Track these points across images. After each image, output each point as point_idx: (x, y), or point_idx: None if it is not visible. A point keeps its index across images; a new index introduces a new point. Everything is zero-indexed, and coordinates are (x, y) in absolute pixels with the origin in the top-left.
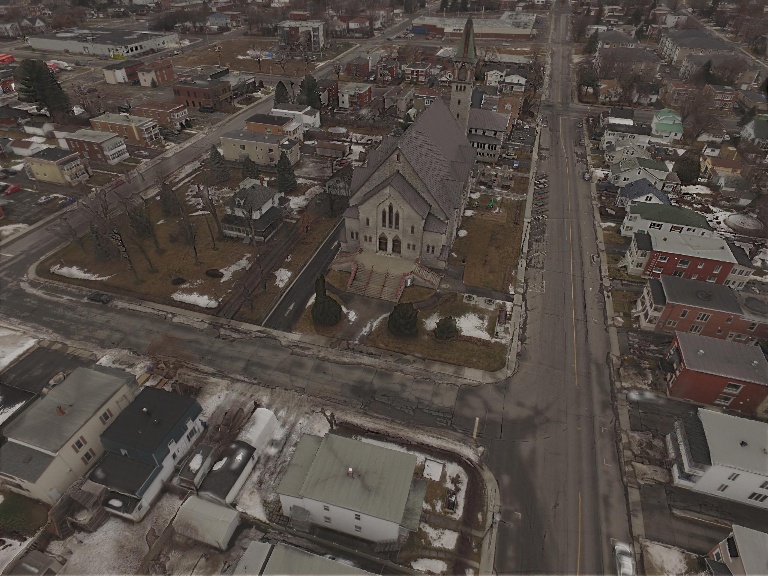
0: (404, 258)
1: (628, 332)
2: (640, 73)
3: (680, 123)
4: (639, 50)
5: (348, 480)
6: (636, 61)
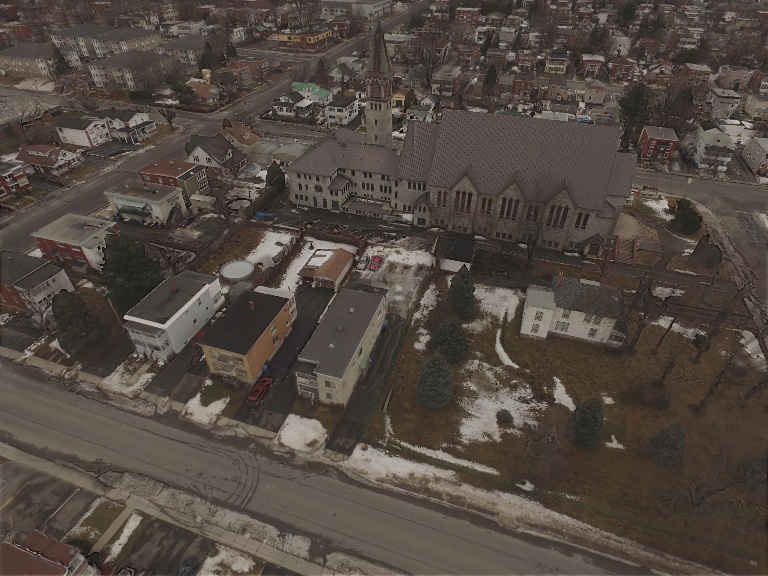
0: None
1: None
2: (164, 72)
3: None
4: (138, 51)
5: None
6: None
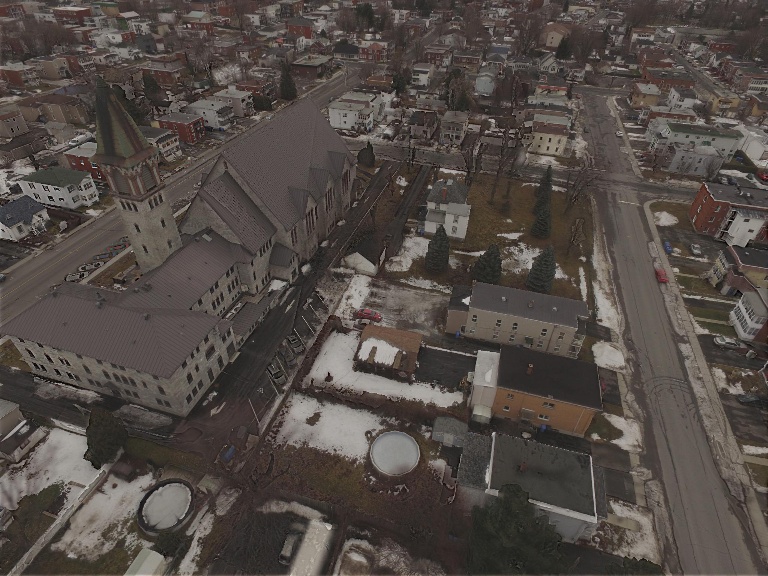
0: None
1: None
2: None
3: None
4: None
5: (351, 106)
6: None
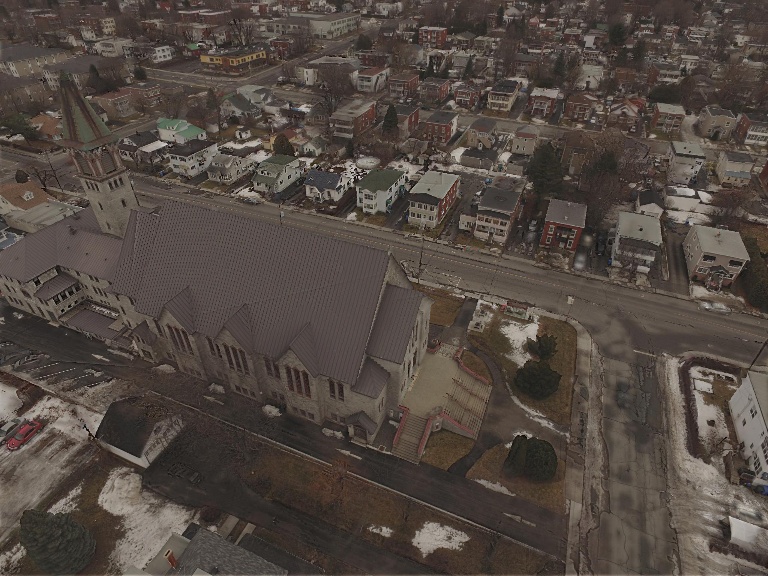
0: (422, 363)
1: (508, 250)
2: (31, 100)
3: (191, 125)
4: None
5: None
6: (16, 88)
